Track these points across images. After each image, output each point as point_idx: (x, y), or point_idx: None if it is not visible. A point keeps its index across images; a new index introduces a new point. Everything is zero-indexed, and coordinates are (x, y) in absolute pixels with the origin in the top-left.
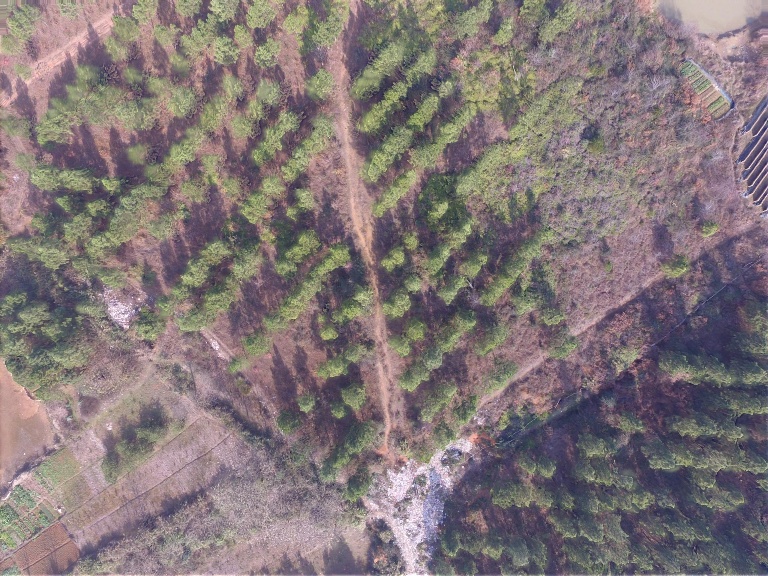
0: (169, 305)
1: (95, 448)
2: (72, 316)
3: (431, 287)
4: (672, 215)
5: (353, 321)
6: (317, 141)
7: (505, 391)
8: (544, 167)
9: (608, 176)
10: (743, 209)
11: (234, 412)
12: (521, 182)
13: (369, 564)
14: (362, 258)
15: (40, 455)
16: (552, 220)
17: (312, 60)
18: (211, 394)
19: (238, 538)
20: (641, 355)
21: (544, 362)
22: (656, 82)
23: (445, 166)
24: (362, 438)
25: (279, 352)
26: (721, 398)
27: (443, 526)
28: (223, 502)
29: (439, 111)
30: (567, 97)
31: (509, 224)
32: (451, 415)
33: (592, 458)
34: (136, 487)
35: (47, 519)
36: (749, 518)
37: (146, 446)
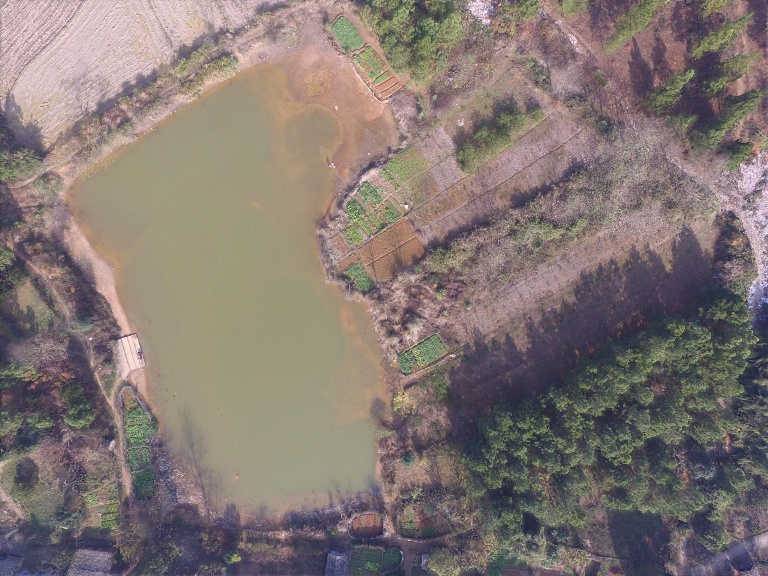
0: None
1: (444, 145)
2: None
3: None
4: None
5: None
6: None
7: None
8: None
9: None
10: None
11: None
12: None
13: (716, 256)
14: None
15: (385, 155)
16: None
17: None
18: (566, 89)
19: (590, 228)
20: None
21: None
22: None
23: None
24: (761, 91)
25: (638, 45)
26: None
27: None
28: (579, 191)
29: None
30: None
31: None
32: None
33: None
34: (485, 182)
35: (394, 215)
36: None
37: (509, 131)
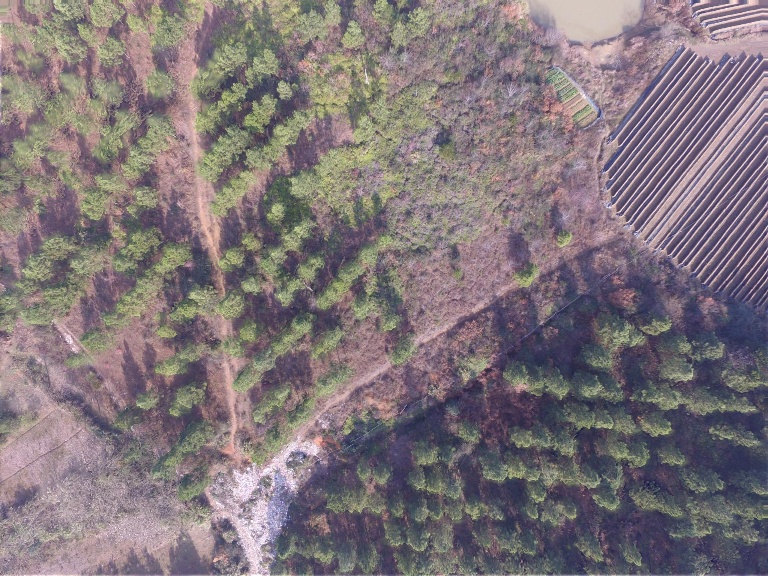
0: (12, 298)
1: None
2: None
3: (276, 289)
4: (529, 224)
5: (201, 320)
6: (155, 140)
7: (350, 395)
8: (391, 172)
9: (460, 182)
10: (605, 220)
11: (85, 406)
12: (367, 186)
13: None
14: (209, 257)
15: None
16: (399, 225)
17: (163, 59)
18: (64, 388)
19: (86, 532)
20: (490, 364)
21: (391, 368)
22: (511, 89)
23: (290, 168)
24: (188, 437)
25: (129, 348)
26: (562, 410)
27: (286, 528)
28: (71, 495)
29: (277, 113)
30: (419, 102)
31: (355, 228)
32: None
33: (425, 466)
34: None
35: None
36: (584, 533)
37: None
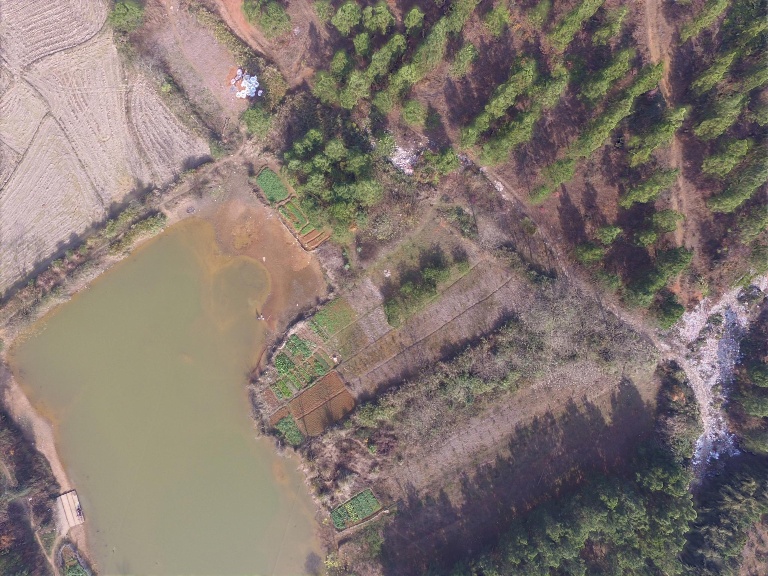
0: None
1: (371, 296)
2: (367, 154)
3: (733, 116)
4: None
5: None
6: None
7: None
8: None
9: None
10: None
11: (518, 253)
12: None
13: (659, 408)
14: (659, 89)
15: (313, 306)
16: None
17: None
18: (493, 237)
19: (523, 381)
20: None
21: None
22: None
23: None
24: (689, 254)
25: (567, 191)
26: None
27: (741, 365)
28: (509, 344)
29: None
30: None
31: None
32: (767, 239)
33: None
34: (414, 334)
35: (323, 368)
36: None
37: (434, 286)
